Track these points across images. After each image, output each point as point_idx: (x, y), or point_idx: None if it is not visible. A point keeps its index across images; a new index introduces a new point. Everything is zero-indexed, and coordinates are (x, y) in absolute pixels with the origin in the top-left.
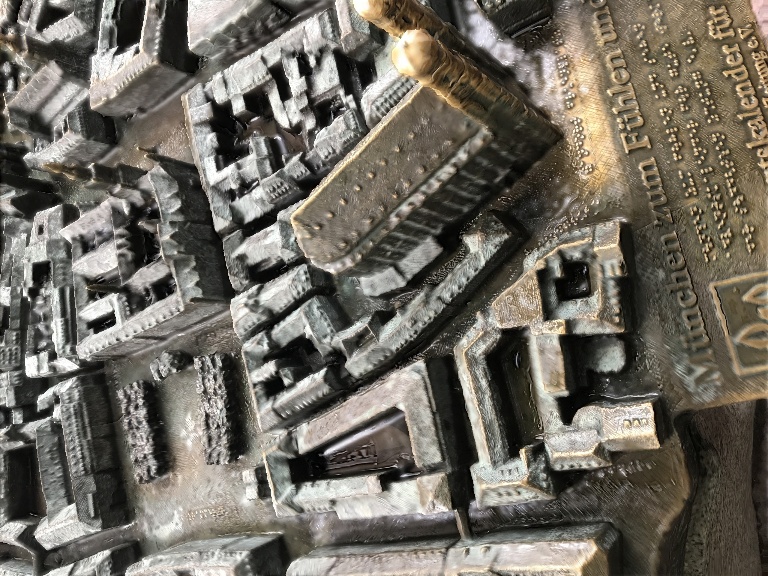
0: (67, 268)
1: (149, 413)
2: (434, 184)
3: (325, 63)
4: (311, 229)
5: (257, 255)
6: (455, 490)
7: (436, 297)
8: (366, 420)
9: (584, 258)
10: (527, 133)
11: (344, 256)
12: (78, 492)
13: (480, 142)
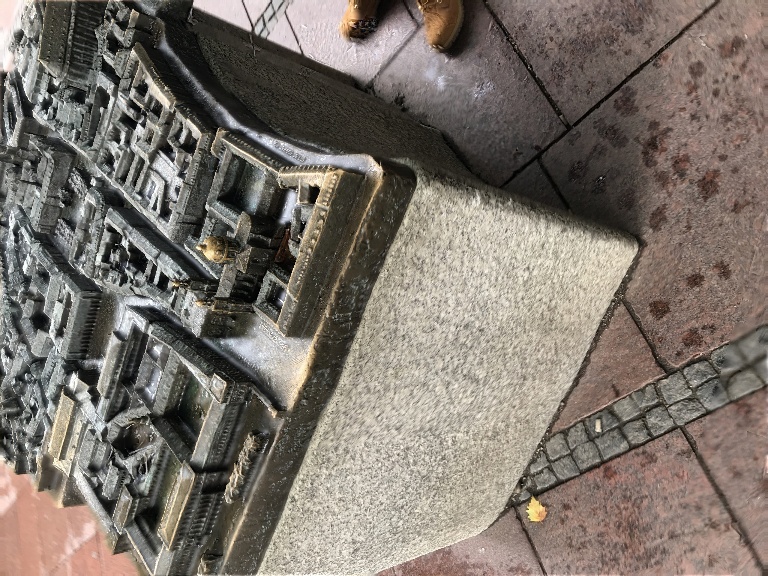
0: (25, 220)
1: (66, 222)
2: (72, 25)
3: None
4: (47, 60)
5: (65, 118)
6: (117, 83)
7: (97, 57)
8: (95, 101)
9: (115, 6)
10: (93, 1)
11: (64, 65)
12: (50, 269)
13: (75, 5)
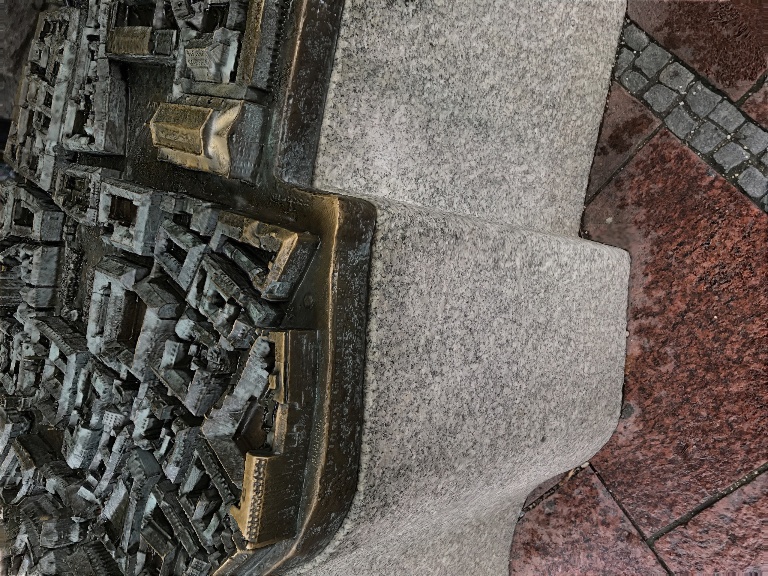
0: None
1: None
2: None
3: (0, 355)
4: None
5: None
6: None
7: None
8: None
9: None
10: None
11: None
12: None
13: None
